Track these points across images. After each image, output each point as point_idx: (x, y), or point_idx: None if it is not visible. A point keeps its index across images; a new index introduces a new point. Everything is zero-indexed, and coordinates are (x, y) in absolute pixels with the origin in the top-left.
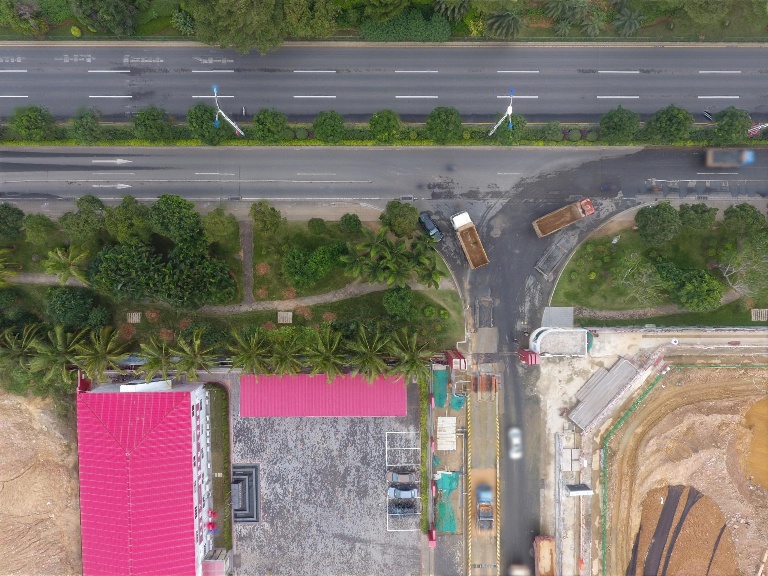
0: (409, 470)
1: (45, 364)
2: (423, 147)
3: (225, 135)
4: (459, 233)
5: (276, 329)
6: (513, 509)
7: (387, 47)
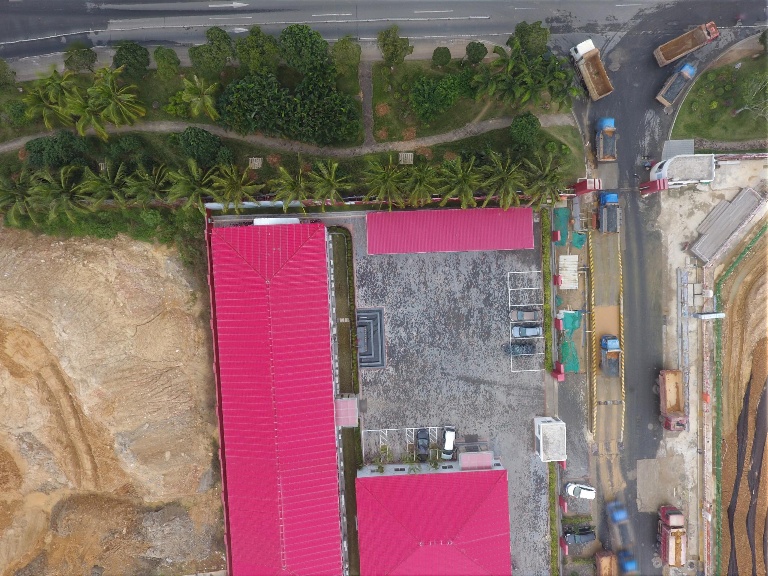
0: (533, 309)
1: (185, 190)
2: None
3: None
4: (584, 60)
5: (397, 170)
6: (636, 346)
7: None
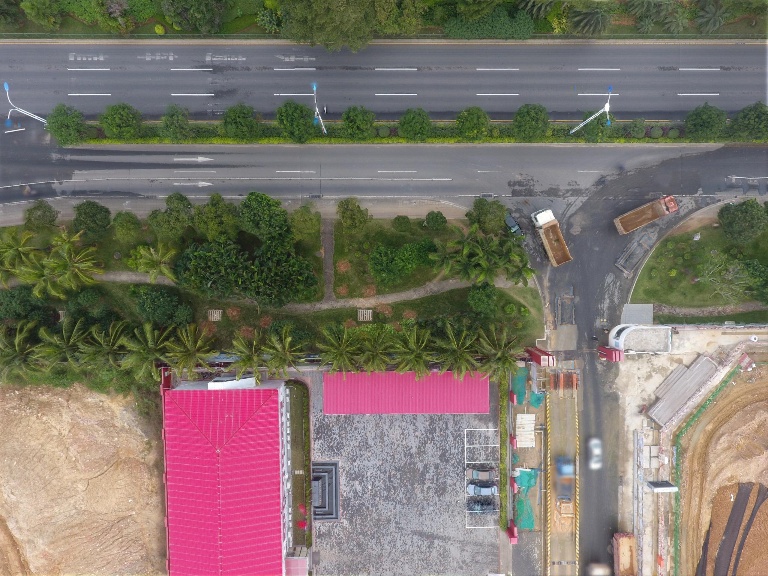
0: (488, 467)
1: (138, 361)
2: (504, 145)
3: (313, 133)
4: (543, 230)
5: (356, 326)
6: (591, 506)
7: (469, 45)
